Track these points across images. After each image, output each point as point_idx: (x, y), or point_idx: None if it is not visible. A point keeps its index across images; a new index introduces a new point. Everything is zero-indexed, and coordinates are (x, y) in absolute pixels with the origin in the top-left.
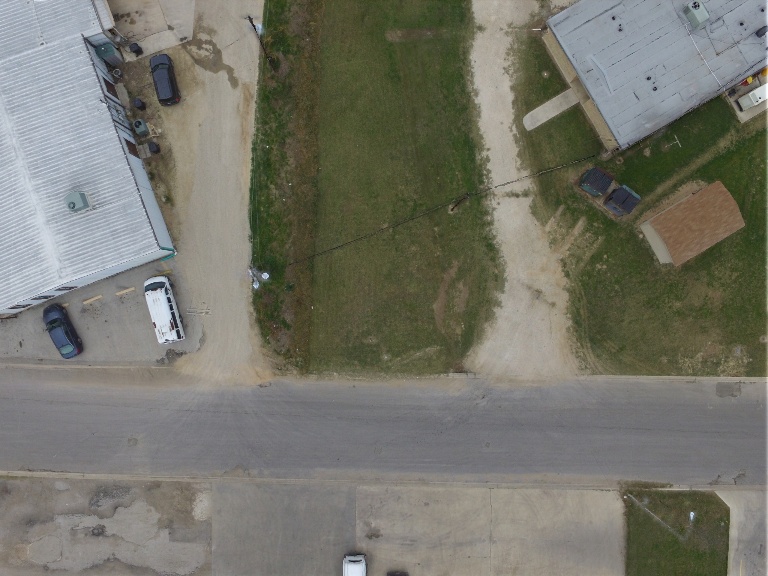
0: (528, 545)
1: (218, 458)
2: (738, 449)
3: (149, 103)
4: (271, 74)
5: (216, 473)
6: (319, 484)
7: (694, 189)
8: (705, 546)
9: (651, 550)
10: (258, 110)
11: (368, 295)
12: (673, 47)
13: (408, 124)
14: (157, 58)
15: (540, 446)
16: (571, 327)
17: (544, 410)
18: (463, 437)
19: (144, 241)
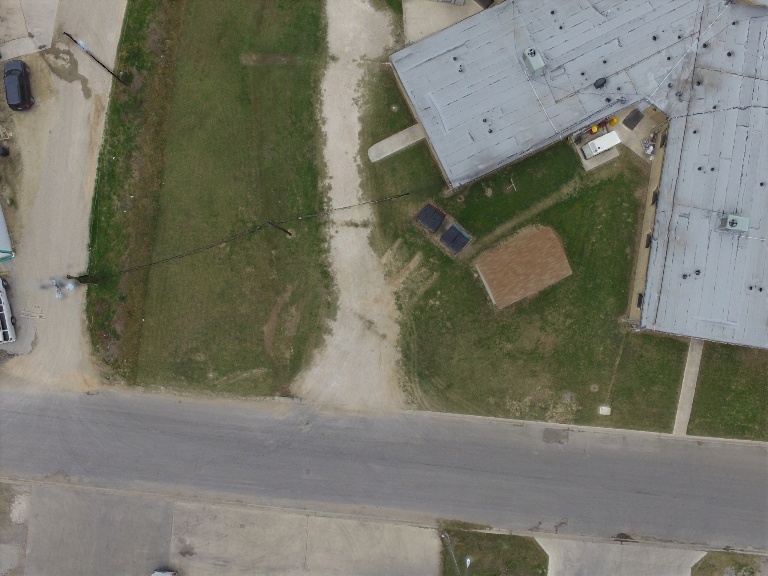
0: None
1: (40, 462)
2: (562, 497)
3: (3, 106)
4: (123, 87)
5: (37, 477)
6: (138, 497)
7: (533, 233)
8: None
9: None
10: (108, 121)
11: (200, 312)
12: (511, 91)
13: (254, 146)
14: (11, 64)
15: (361, 477)
16: (400, 360)
17: (367, 441)
18: (284, 462)
19: None
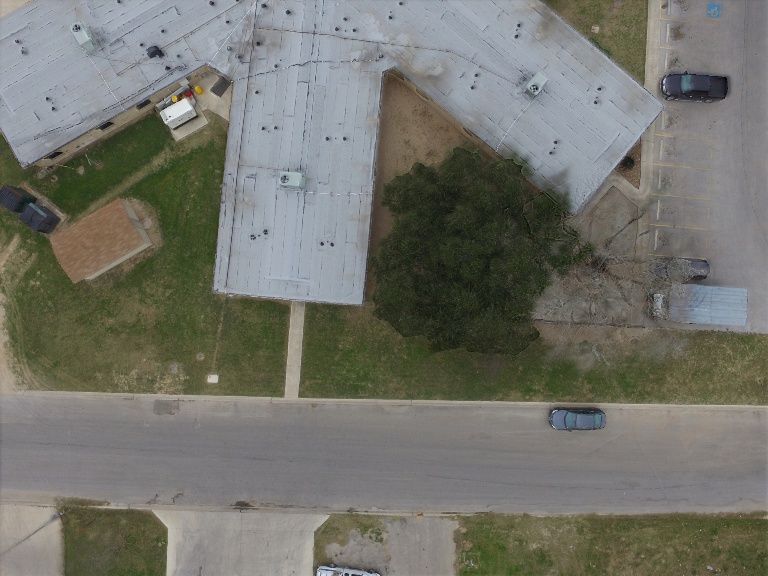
0: None
1: None
2: (176, 468)
3: None
4: None
5: None
6: None
7: None
8: (143, 567)
9: (88, 569)
10: None
11: None
12: (72, 68)
13: None
14: None
15: None
16: (8, 342)
17: None
18: None
19: None
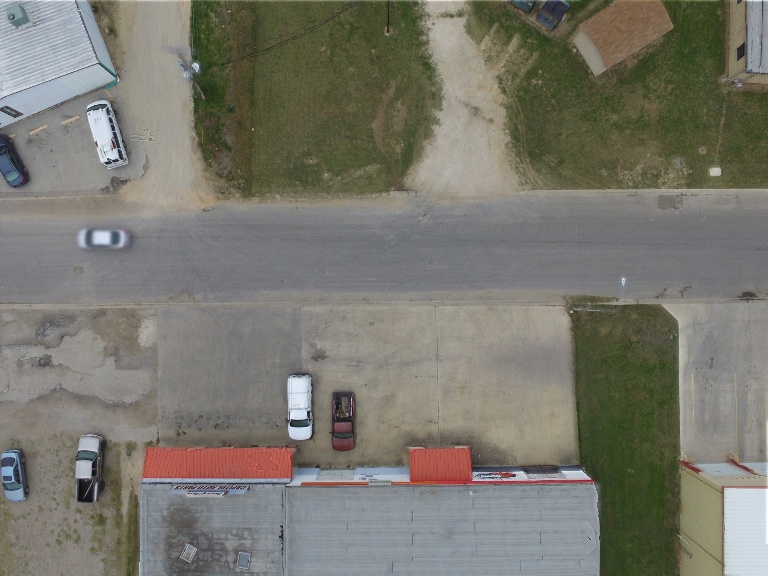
0: (475, 363)
1: (163, 283)
2: (683, 262)
3: None
4: None
5: (161, 299)
6: (264, 307)
7: None
8: (655, 361)
9: (600, 366)
10: None
11: (308, 116)
12: None
13: None
14: None
15: (483, 262)
16: (510, 143)
17: (486, 226)
18: (406, 255)
19: (83, 54)
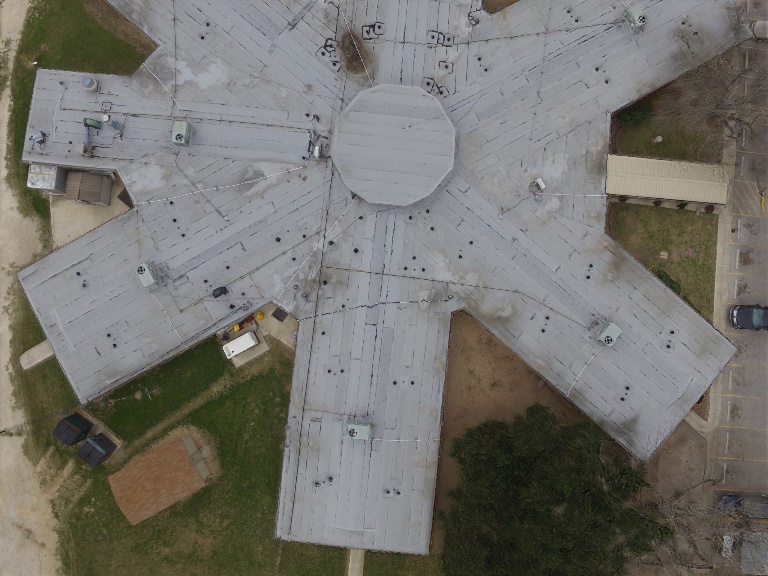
0: None
1: None
2: None
3: None
4: None
5: None
6: None
7: (184, 434)
8: None
9: None
10: None
11: None
12: (135, 304)
13: None
14: None
15: None
16: (60, 569)
17: None
18: None
19: None
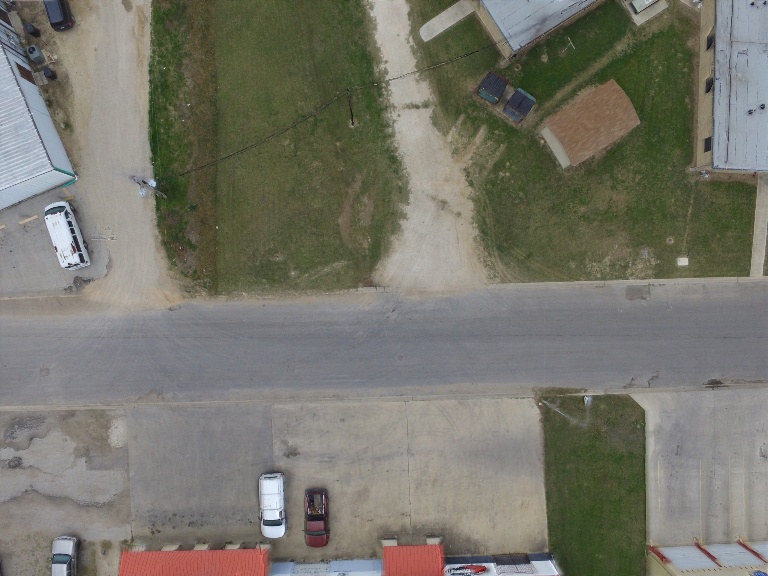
0: (446, 456)
1: (131, 384)
2: (650, 351)
3: (43, 30)
4: None
5: (130, 399)
6: (234, 405)
7: None
8: (622, 449)
9: (568, 456)
10: (153, 32)
11: (273, 213)
12: None
13: (305, 40)
14: None
15: (453, 357)
16: (478, 236)
17: (455, 320)
18: (375, 351)
19: (37, 161)
